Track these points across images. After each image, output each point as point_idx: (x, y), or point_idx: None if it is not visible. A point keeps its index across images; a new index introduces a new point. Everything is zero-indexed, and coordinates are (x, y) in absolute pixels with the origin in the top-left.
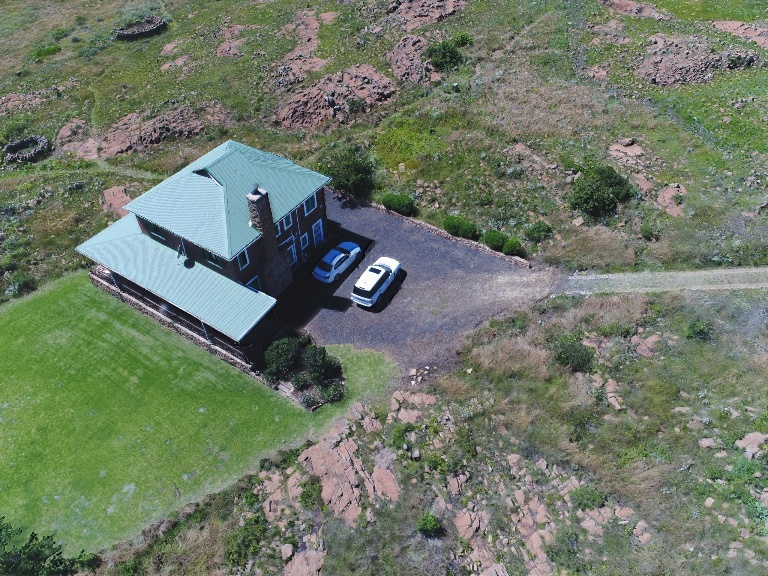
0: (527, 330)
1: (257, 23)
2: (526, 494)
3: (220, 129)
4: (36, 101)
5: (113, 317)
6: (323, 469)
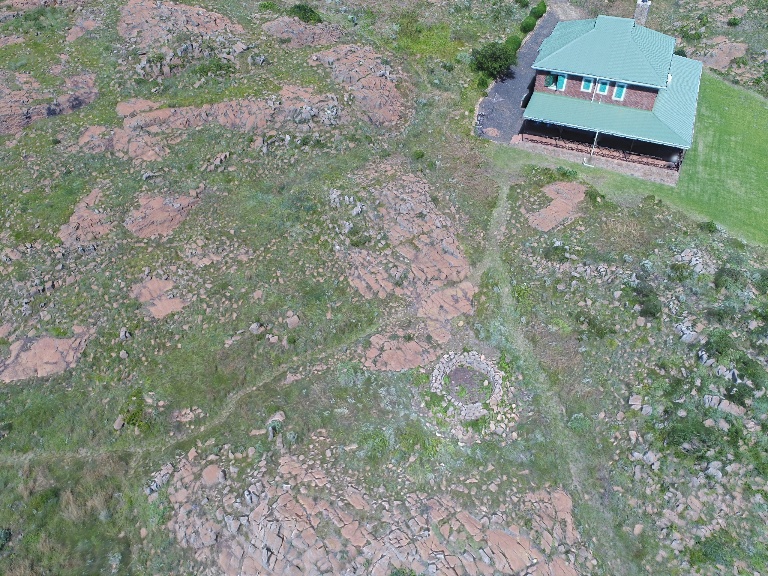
0: (600, 9)
1: (78, 195)
2: (700, 4)
3: (421, 153)
4: (294, 467)
5: (696, 163)
6: (728, 58)
